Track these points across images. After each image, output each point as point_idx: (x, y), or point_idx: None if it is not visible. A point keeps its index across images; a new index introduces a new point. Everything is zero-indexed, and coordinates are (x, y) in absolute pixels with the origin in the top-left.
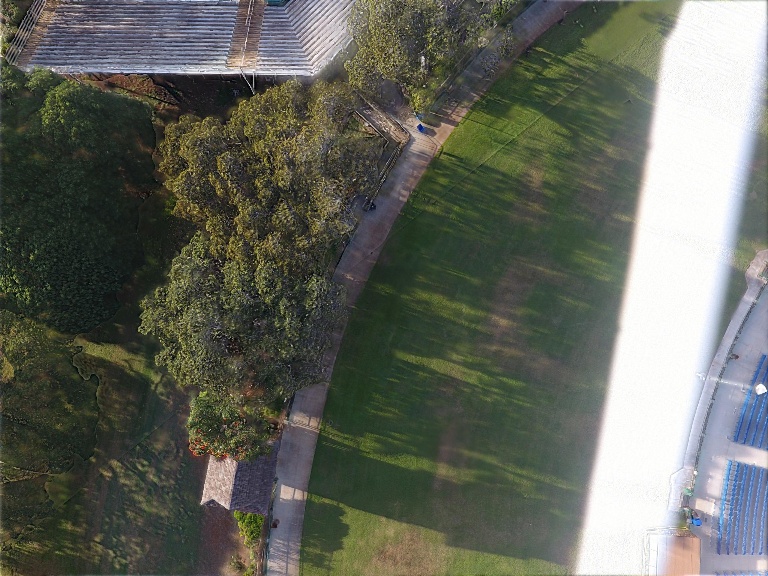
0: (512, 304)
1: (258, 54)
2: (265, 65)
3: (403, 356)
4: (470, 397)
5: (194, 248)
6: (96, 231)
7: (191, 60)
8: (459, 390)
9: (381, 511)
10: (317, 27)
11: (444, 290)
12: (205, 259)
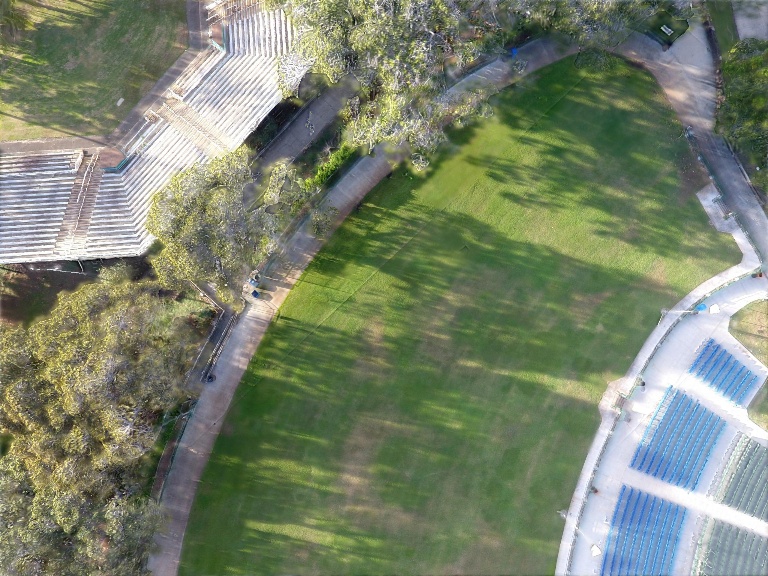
0: (362, 461)
1: (88, 234)
2: (92, 247)
3: (253, 526)
4: (325, 559)
5: (14, 456)
6: None
7: (19, 247)
8: (314, 554)
9: None
10: (148, 199)
11: (291, 454)
12: (21, 471)
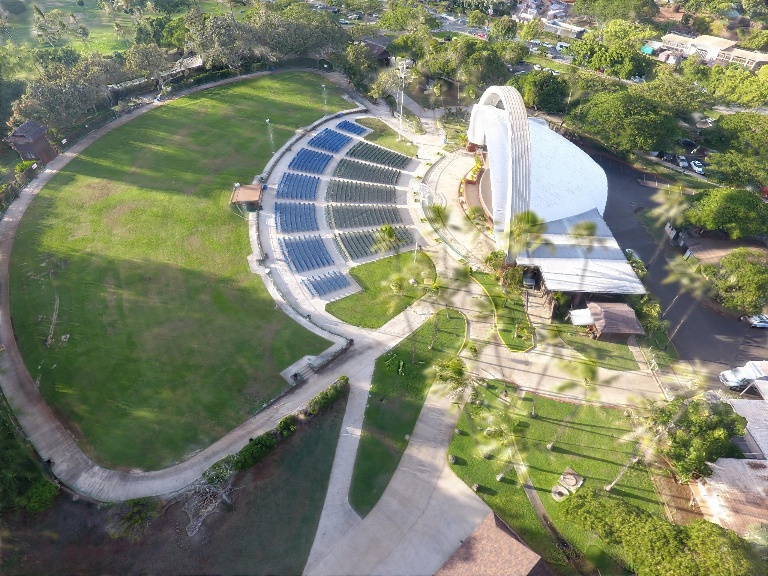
0: (185, 133)
1: None
2: None
3: (127, 141)
4: (156, 152)
5: None
6: (6, 104)
7: None
8: (151, 150)
9: (95, 176)
10: None
11: None
12: None
